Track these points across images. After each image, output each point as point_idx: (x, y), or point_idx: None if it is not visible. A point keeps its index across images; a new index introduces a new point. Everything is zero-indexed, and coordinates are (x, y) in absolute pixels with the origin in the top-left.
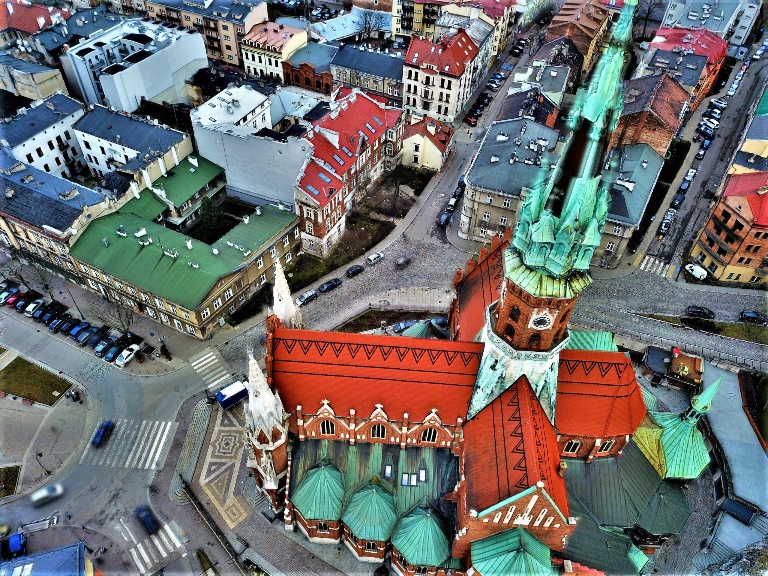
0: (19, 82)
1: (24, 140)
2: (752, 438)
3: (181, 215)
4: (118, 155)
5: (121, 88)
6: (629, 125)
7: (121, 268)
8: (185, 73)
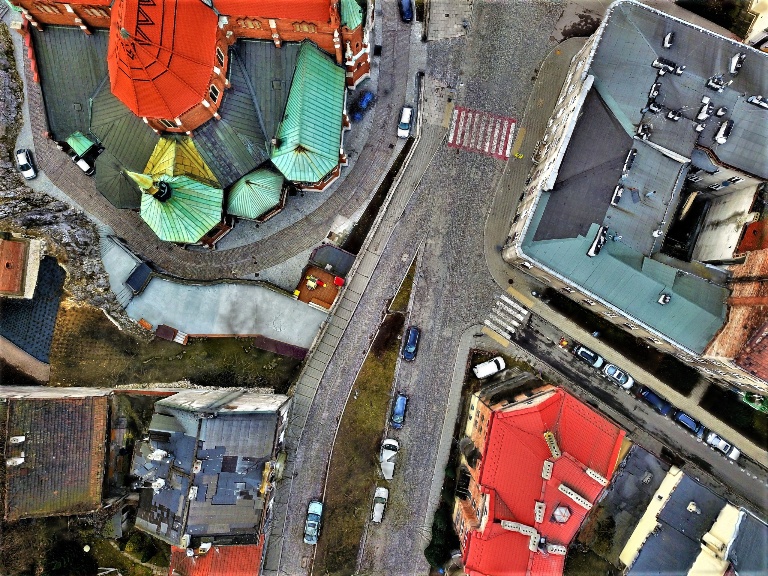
0: None
1: None
2: (221, 328)
3: None
4: None
5: None
6: (761, 284)
7: None
8: None
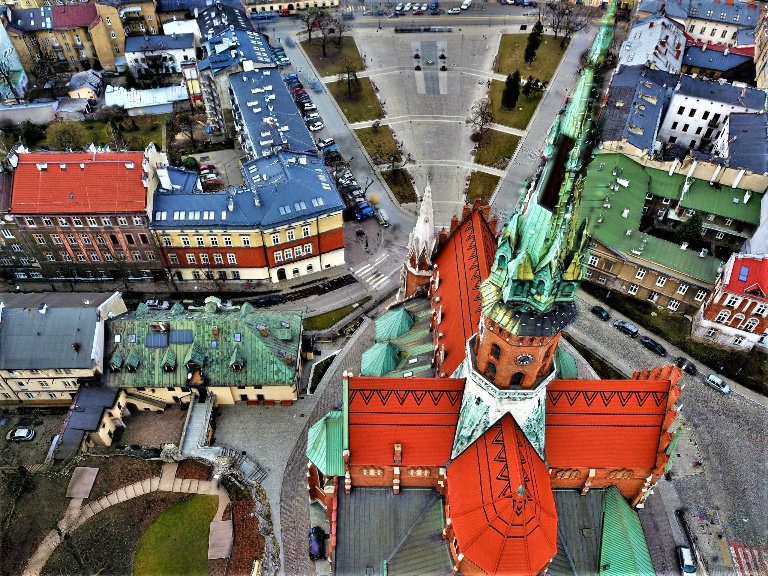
0: (764, 70)
1: (690, 95)
2: None
3: (681, 216)
4: (722, 153)
5: None
6: None
7: None
8: None
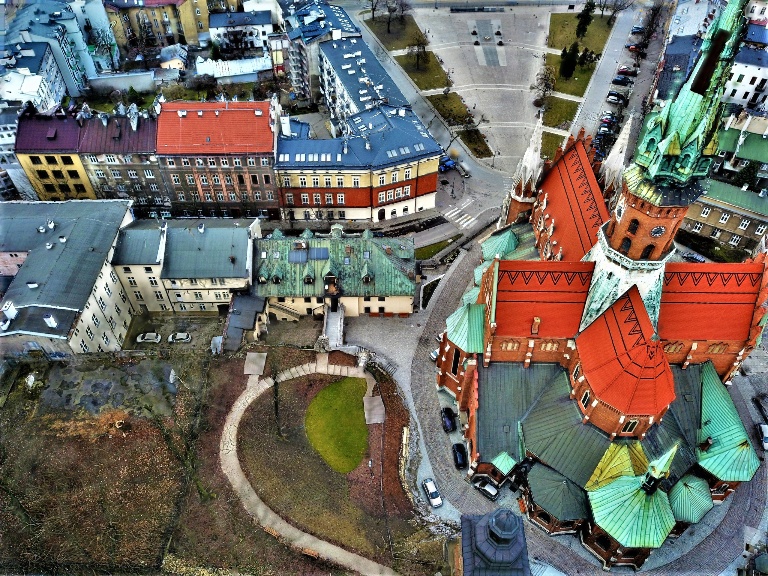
0: None
1: (739, 61)
2: None
3: (736, 167)
4: None
5: None
6: None
7: None
8: None
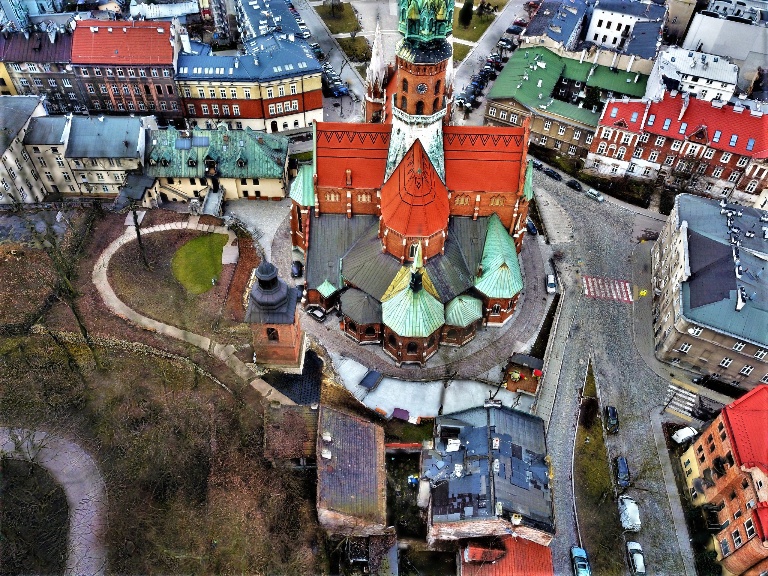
0: None
1: (606, 9)
2: None
3: None
4: None
5: (696, 27)
6: None
7: (510, 67)
8: (766, 61)
